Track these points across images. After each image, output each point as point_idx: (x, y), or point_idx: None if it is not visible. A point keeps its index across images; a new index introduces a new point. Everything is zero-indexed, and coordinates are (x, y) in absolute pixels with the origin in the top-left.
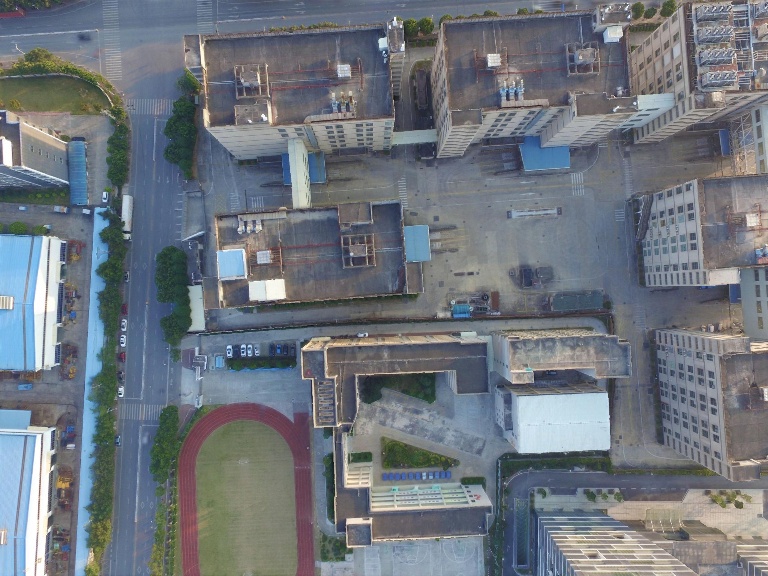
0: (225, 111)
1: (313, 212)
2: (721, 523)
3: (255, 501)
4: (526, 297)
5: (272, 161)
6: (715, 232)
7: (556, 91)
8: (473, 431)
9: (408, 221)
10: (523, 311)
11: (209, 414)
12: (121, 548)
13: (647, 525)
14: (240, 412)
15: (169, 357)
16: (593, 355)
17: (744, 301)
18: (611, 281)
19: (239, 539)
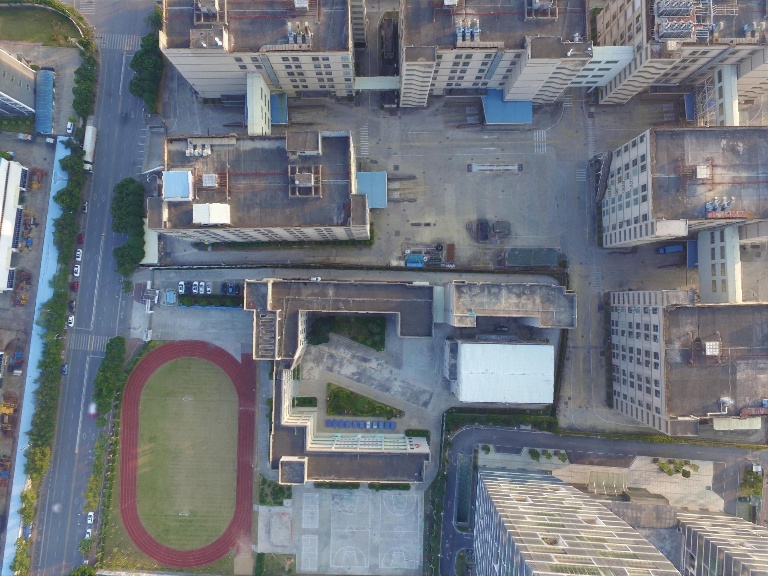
0: (182, 36)
1: (263, 140)
2: (668, 493)
3: (197, 439)
4: (482, 251)
5: (235, 100)
6: (666, 184)
7: (513, 35)
8: (420, 383)
9: (368, 169)
10: (478, 265)
11: (157, 349)
12: (60, 478)
13: (590, 487)
14: (188, 349)
15: (121, 290)
16: (539, 304)
17: (700, 266)
18: (568, 240)
19: (178, 477)
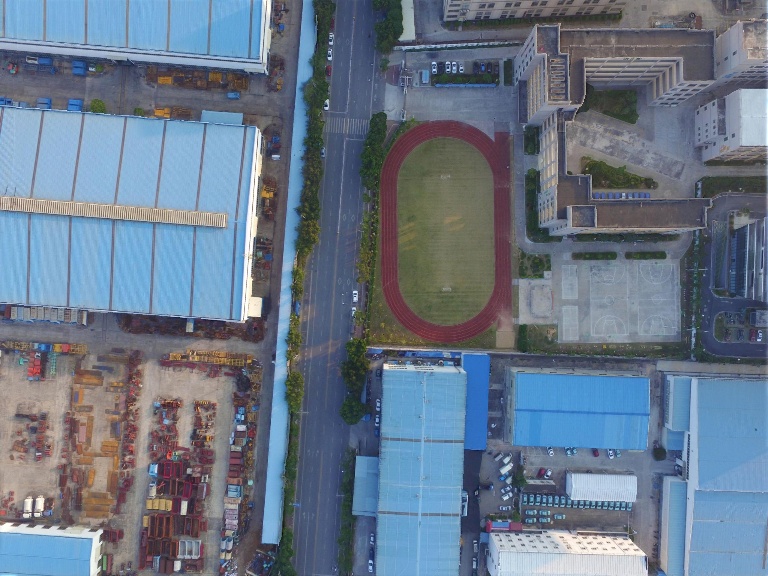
0: None
1: None
2: None
3: (455, 217)
4: (728, 23)
5: None
6: None
7: None
8: (672, 154)
9: None
10: None
11: (412, 130)
12: (322, 259)
13: None
14: (442, 129)
15: (374, 73)
16: None
17: None
18: None
19: (438, 254)
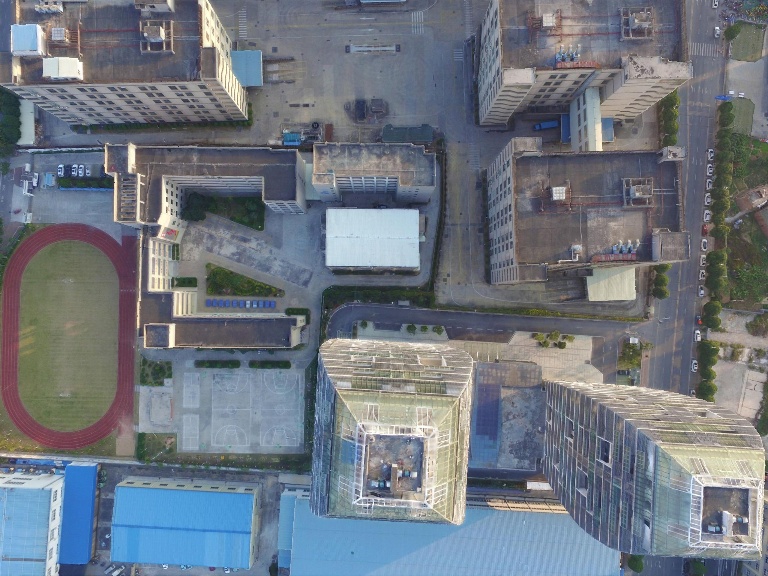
0: None
1: None
2: (547, 367)
3: (78, 321)
4: (360, 131)
5: None
6: (516, 36)
7: None
8: (300, 262)
9: None
10: None
11: (37, 232)
12: None
13: None
14: (69, 232)
15: None
16: (399, 164)
17: (572, 137)
18: (446, 119)
19: (59, 359)
